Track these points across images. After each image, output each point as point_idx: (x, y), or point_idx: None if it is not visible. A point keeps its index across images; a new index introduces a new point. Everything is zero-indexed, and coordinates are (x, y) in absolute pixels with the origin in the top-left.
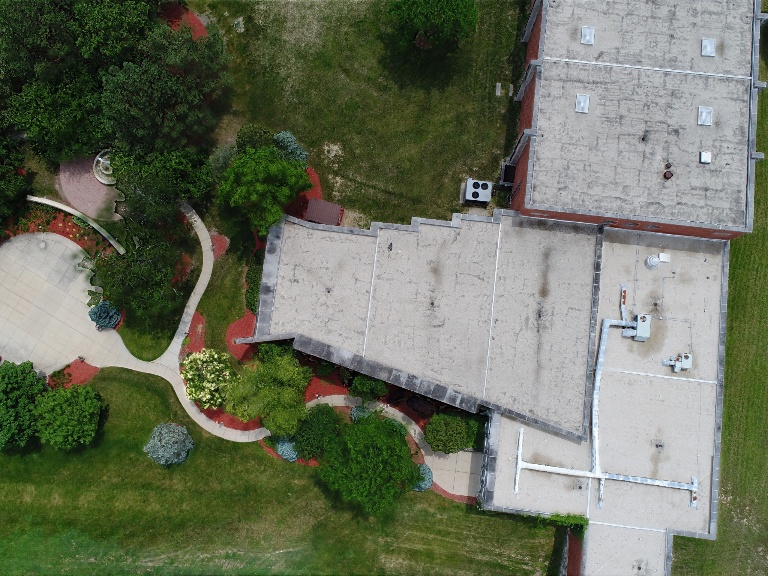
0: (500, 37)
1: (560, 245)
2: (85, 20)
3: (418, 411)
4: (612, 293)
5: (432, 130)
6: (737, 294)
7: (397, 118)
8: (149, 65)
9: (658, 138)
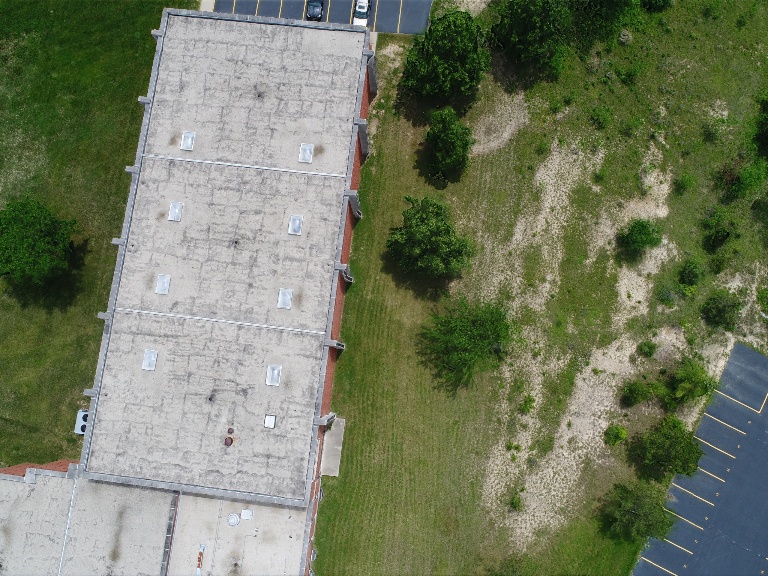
0: None
1: (136, 503)
2: None
3: None
4: (191, 552)
5: (51, 353)
6: (350, 536)
7: (18, 339)
8: None
9: (225, 398)
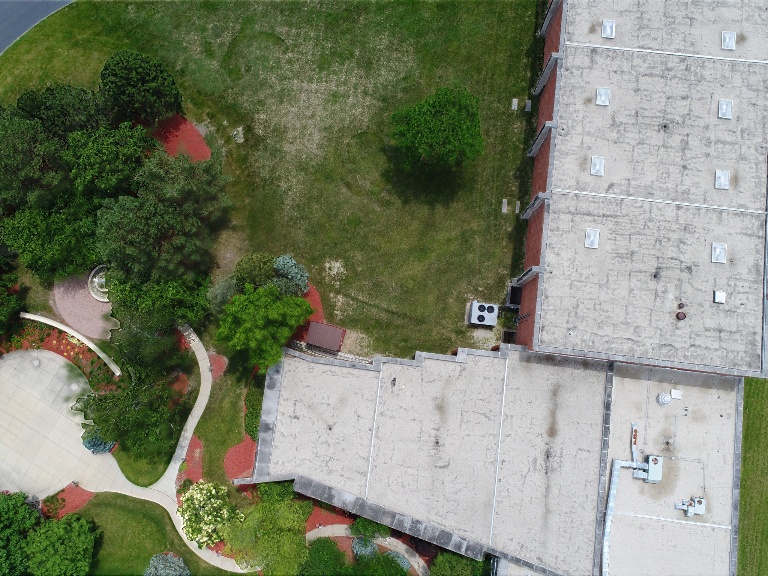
0: (506, 151)
1: (569, 382)
2: (79, 152)
3: (422, 555)
4: (622, 431)
5: (436, 248)
6: (751, 423)
7: (400, 235)
8: (145, 194)
9: (670, 275)
